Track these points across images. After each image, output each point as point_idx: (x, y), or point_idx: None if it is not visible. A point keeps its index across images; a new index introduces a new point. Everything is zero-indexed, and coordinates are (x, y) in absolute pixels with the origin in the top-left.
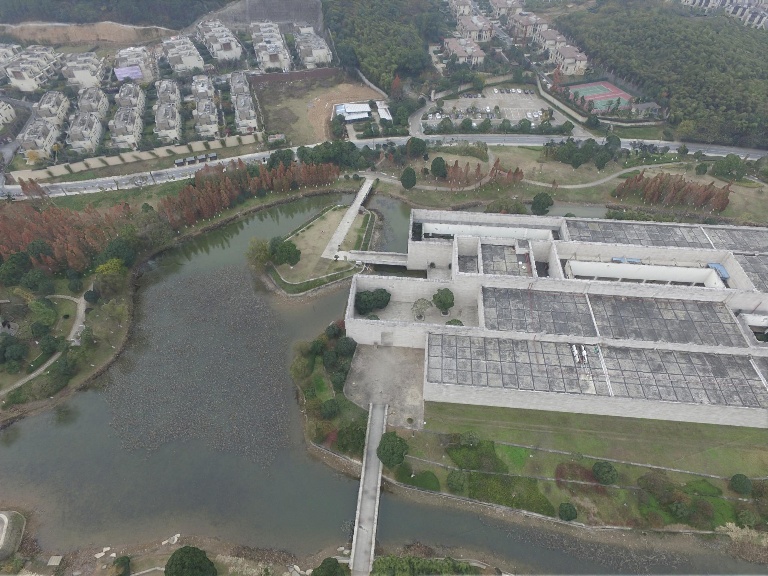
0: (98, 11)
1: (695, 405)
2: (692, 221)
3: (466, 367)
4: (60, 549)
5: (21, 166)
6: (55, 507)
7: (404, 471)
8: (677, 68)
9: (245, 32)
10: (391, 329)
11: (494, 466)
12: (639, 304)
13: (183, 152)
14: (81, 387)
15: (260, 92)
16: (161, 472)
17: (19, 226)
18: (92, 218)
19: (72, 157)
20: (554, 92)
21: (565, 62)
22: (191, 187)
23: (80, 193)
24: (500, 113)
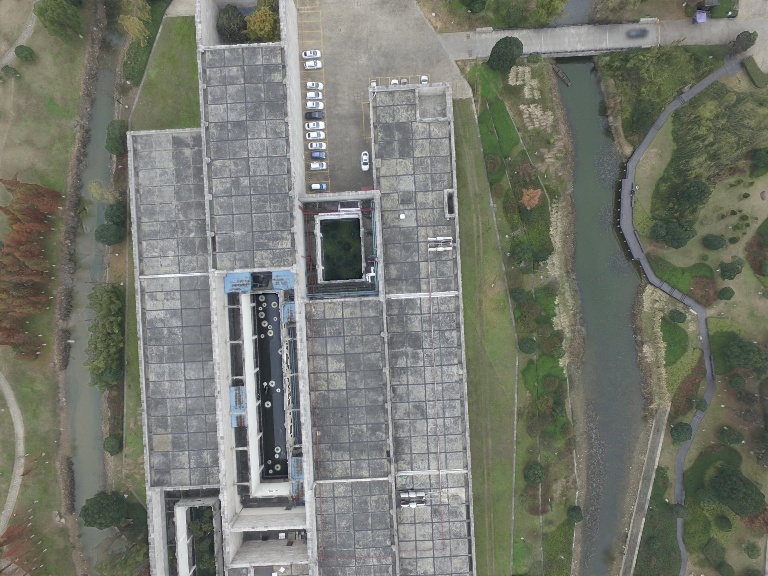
0: None
1: None
2: (80, 236)
3: None
4: None
5: None
6: None
7: None
8: None
9: None
10: None
11: None
12: (324, 414)
13: None
14: None
15: None
16: None
17: None
18: None
19: None
20: None
21: None
22: None
23: None
24: None
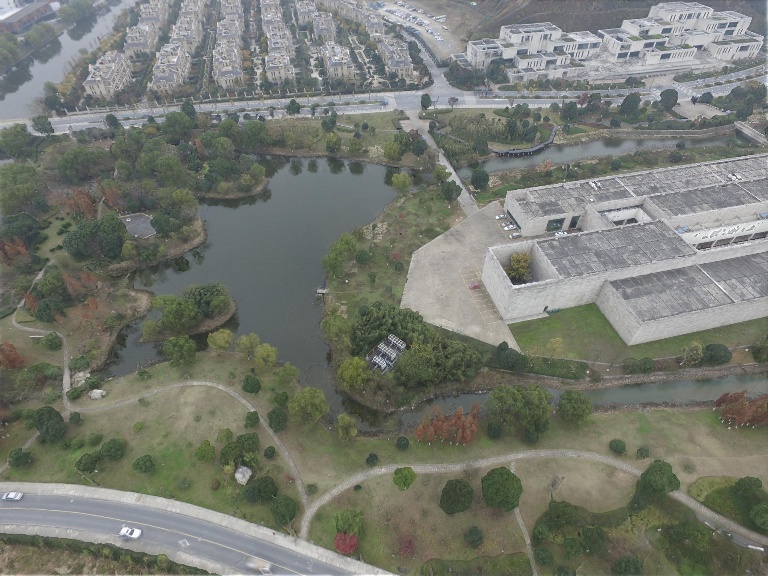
0: None
1: (660, 169)
2: None
3: None
4: None
5: None
6: None
7: (755, 145)
8: None
9: None
10: None
11: None
12: None
13: None
14: None
15: None
16: None
17: None
18: None
19: None
20: None
21: None
22: None
23: None
24: None
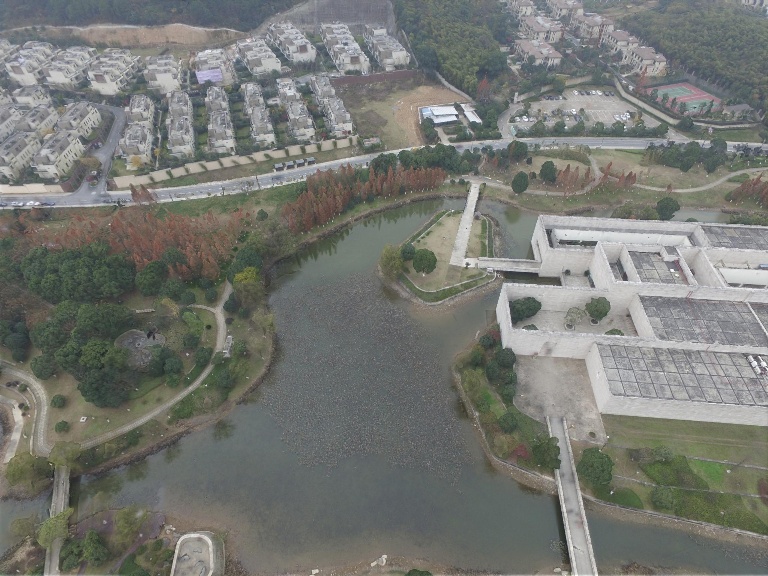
0: (168, 13)
1: None
2: None
3: (646, 379)
4: (267, 571)
5: (122, 171)
6: (249, 527)
7: (602, 488)
8: (766, 69)
9: (313, 34)
10: (556, 340)
11: (694, 482)
12: None
13: (279, 156)
14: (241, 400)
15: (341, 95)
16: (348, 489)
17: (147, 234)
18: (213, 225)
19: (173, 162)
20: (638, 94)
21: (643, 63)
22: (309, 193)
23: (187, 199)
24: (587, 115)
